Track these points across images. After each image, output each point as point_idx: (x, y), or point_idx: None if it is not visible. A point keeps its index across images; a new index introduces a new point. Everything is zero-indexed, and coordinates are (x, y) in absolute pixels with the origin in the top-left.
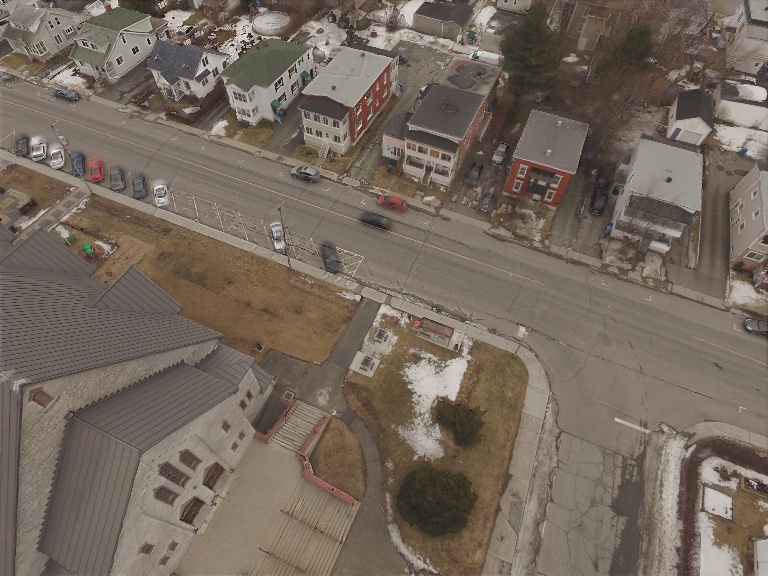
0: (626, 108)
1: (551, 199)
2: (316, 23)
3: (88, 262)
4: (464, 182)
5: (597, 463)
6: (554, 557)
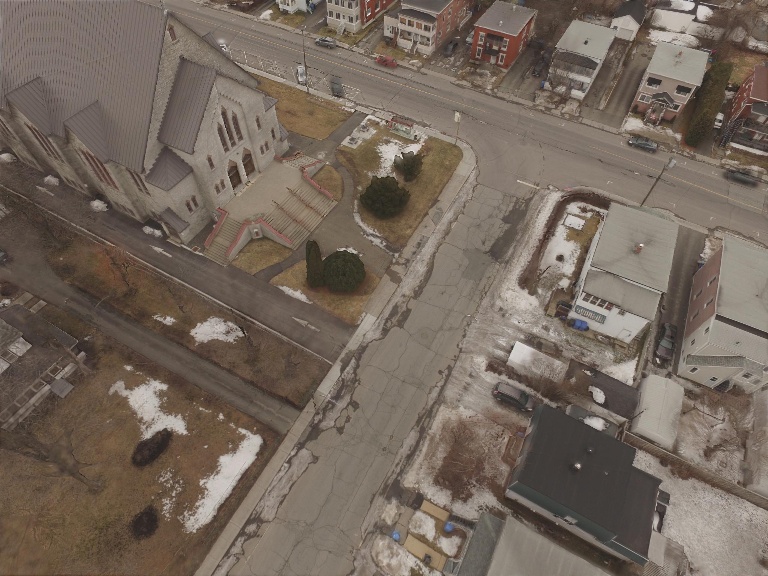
0: (581, 16)
1: (503, 62)
2: None
3: None
4: (442, 53)
5: (498, 199)
6: (457, 237)
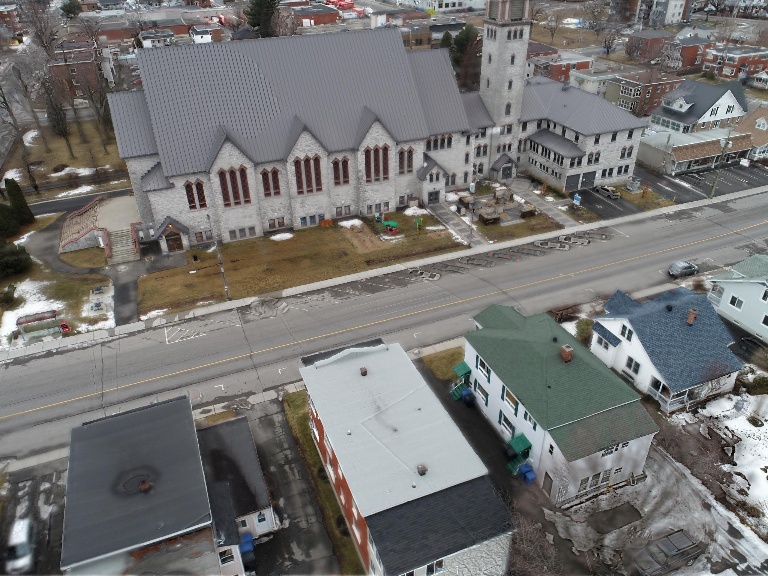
0: None
1: None
2: None
3: None
4: None
5: None
6: None
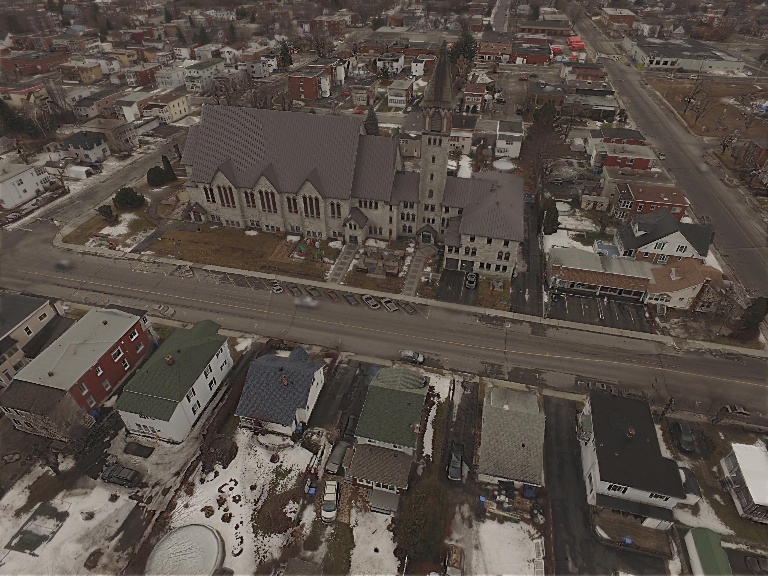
0: None
1: None
2: None
3: None
4: None
5: None
6: None
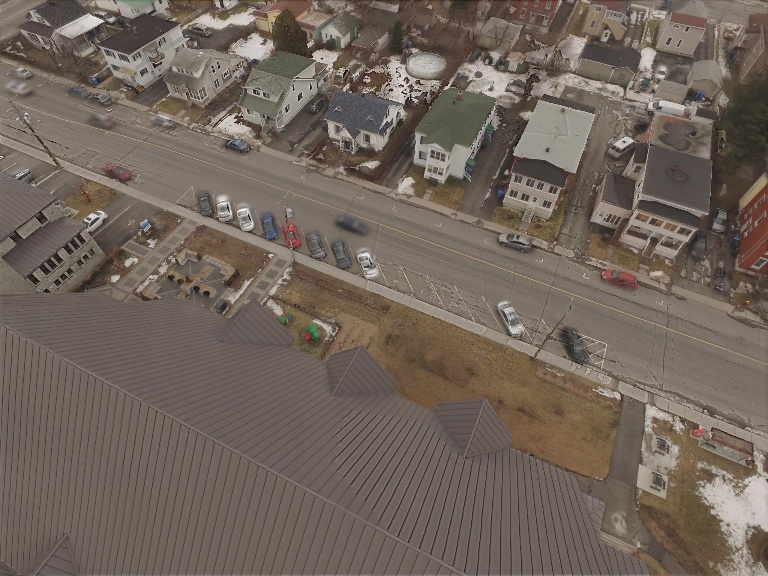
0: None
1: None
2: (472, 66)
3: (312, 345)
4: (688, 254)
5: None
6: None
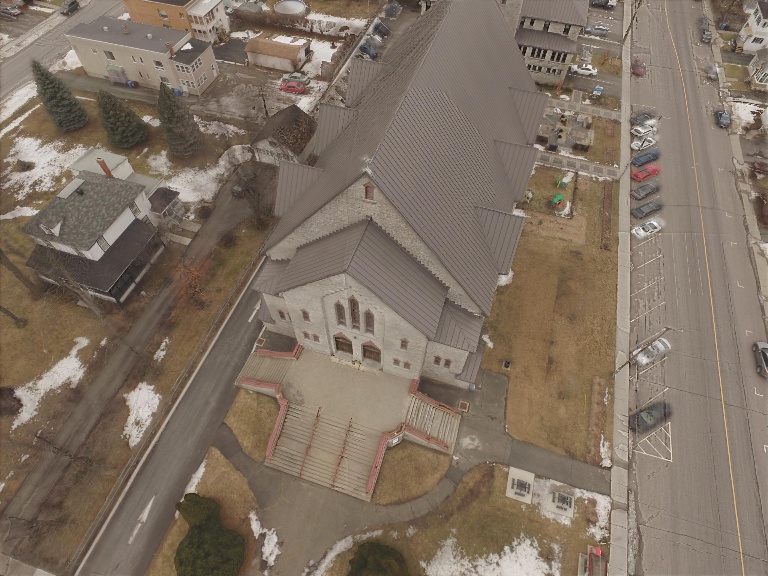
0: None
1: None
2: None
3: (546, 205)
4: None
5: None
6: None
